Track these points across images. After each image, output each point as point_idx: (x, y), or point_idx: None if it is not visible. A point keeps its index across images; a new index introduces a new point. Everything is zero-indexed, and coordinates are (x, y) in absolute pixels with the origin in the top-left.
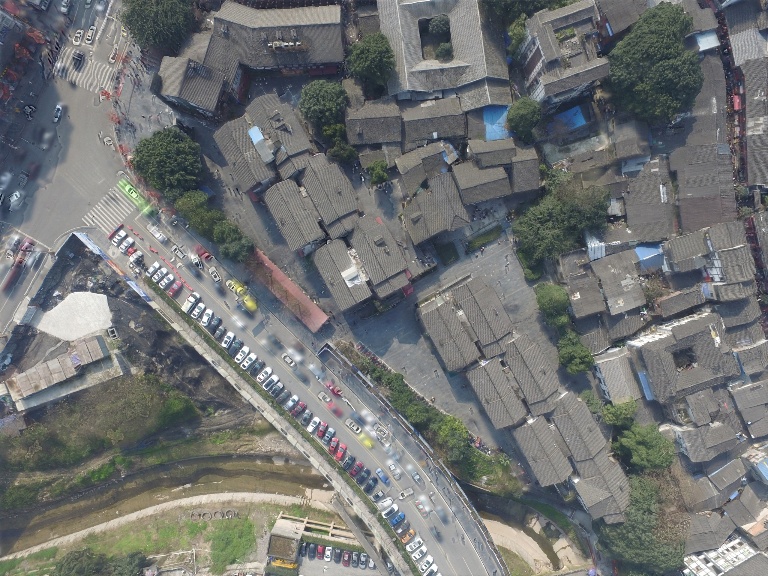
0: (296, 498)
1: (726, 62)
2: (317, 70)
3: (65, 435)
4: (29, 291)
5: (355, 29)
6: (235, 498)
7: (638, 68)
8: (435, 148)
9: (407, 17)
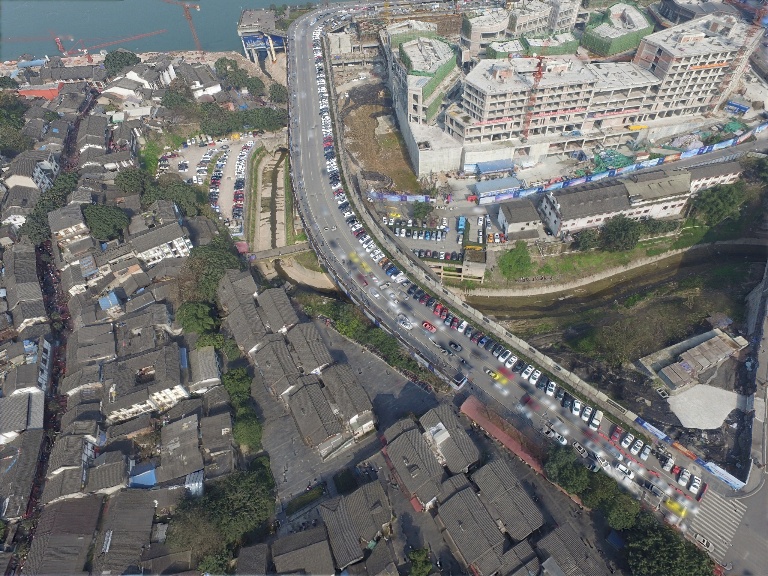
0: (473, 294)
1: None
2: None
3: None
4: (764, 428)
5: None
6: (521, 291)
7: None
8: None
9: None
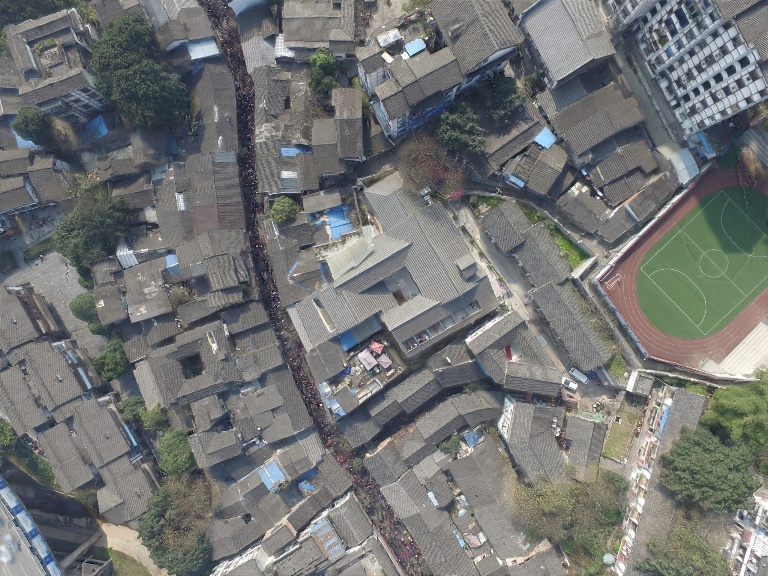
0: None
1: None
2: None
3: None
4: None
5: None
6: None
7: (104, 78)
8: None
9: None
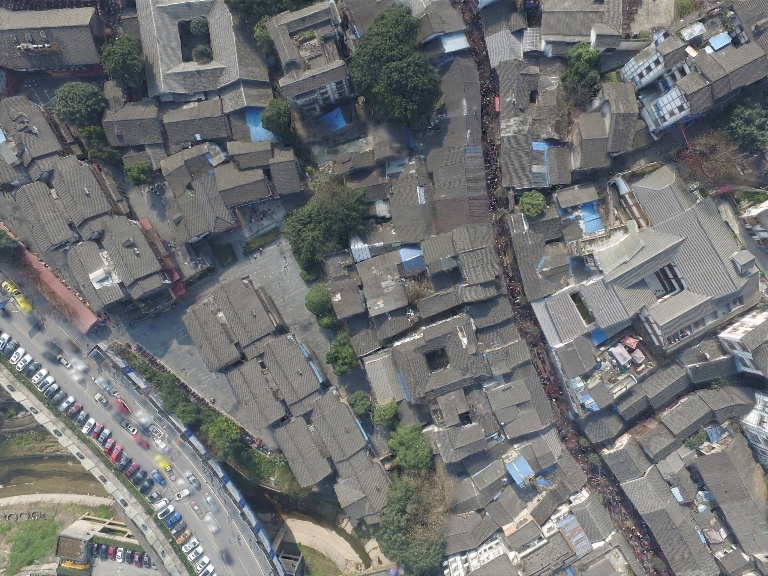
0: (107, 499)
1: (488, 64)
2: (81, 72)
3: None
4: None
5: (121, 31)
6: (44, 499)
7: (370, 70)
8: (199, 150)
9: (164, 19)
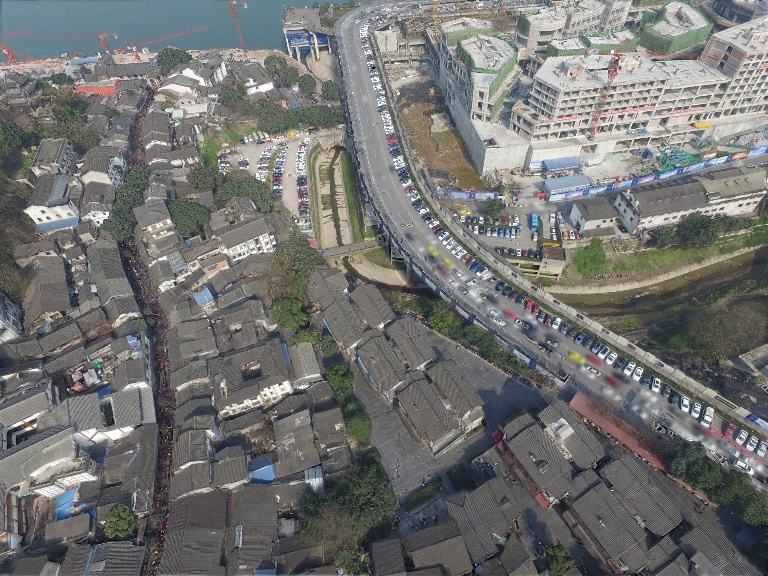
0: None
1: None
2: None
3: None
4: None
5: None
6: (597, 289)
7: None
8: None
9: None
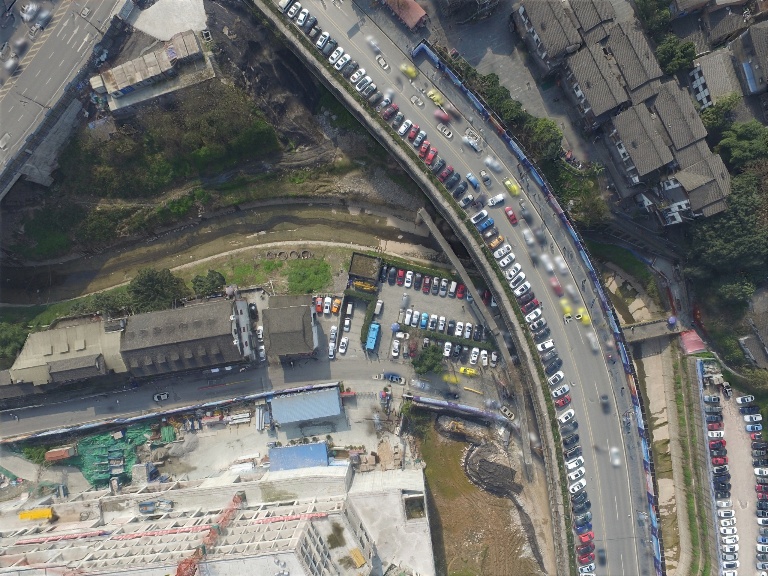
0: (371, 248)
1: None
2: None
3: (150, 155)
4: None
5: None
6: (310, 243)
7: None
8: None
9: None
